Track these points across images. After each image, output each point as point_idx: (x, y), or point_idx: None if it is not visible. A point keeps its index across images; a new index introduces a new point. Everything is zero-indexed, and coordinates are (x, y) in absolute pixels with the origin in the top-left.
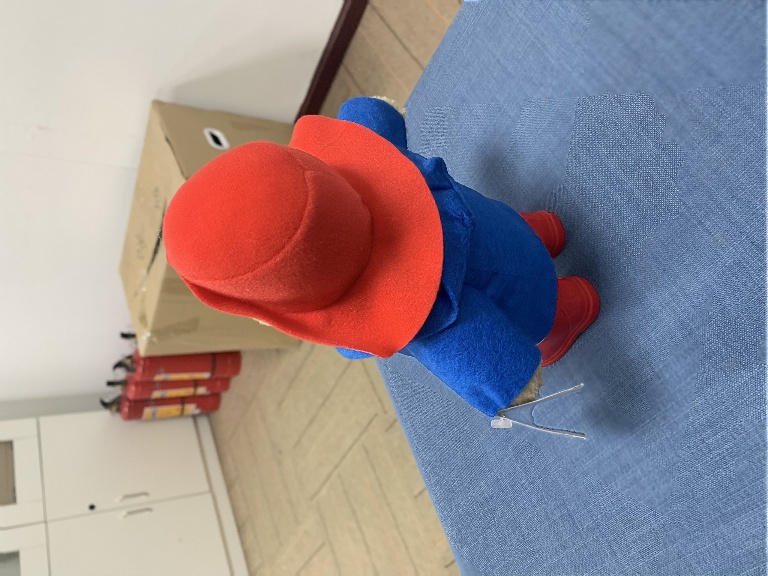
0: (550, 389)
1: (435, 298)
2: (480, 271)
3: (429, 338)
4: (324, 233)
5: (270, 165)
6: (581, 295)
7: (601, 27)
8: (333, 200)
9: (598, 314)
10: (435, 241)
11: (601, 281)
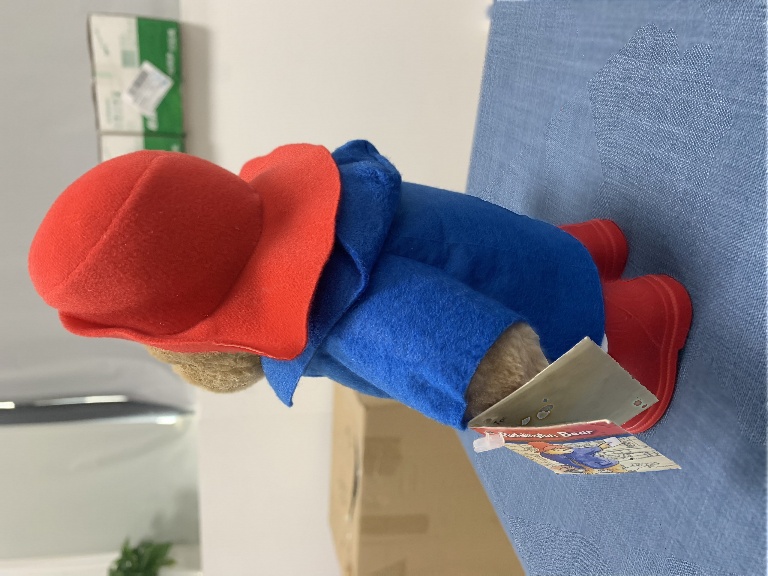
0: (675, 456)
1: (326, 258)
2: (425, 241)
3: (341, 323)
4: (166, 203)
5: (119, 157)
6: (652, 289)
7: (585, 4)
8: (187, 174)
9: (692, 311)
10: (329, 199)
11: (680, 265)
